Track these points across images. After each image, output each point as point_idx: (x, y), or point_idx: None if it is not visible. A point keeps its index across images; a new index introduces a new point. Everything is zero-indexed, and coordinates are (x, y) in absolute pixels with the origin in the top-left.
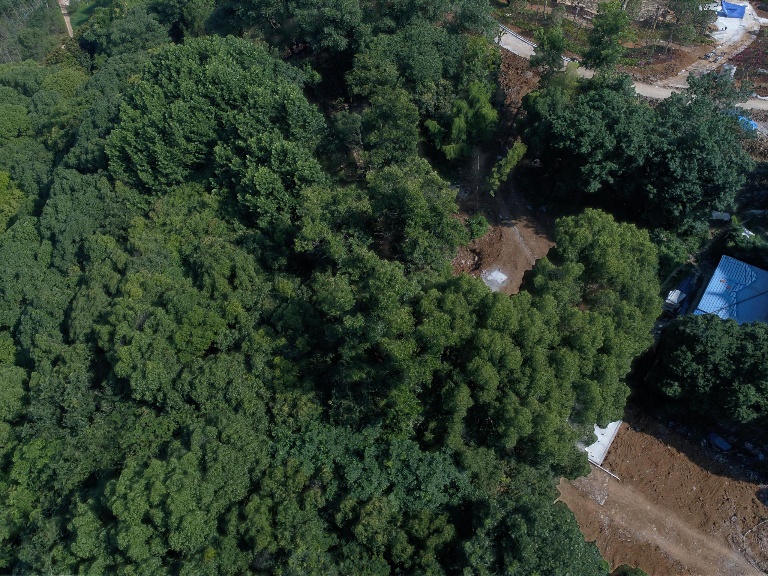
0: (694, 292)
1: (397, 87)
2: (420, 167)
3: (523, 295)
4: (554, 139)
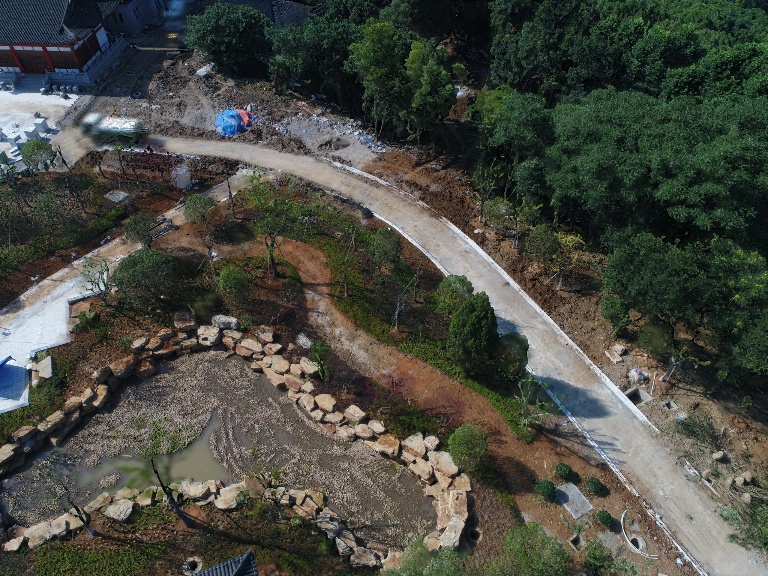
0: None
1: None
2: None
3: None
4: None
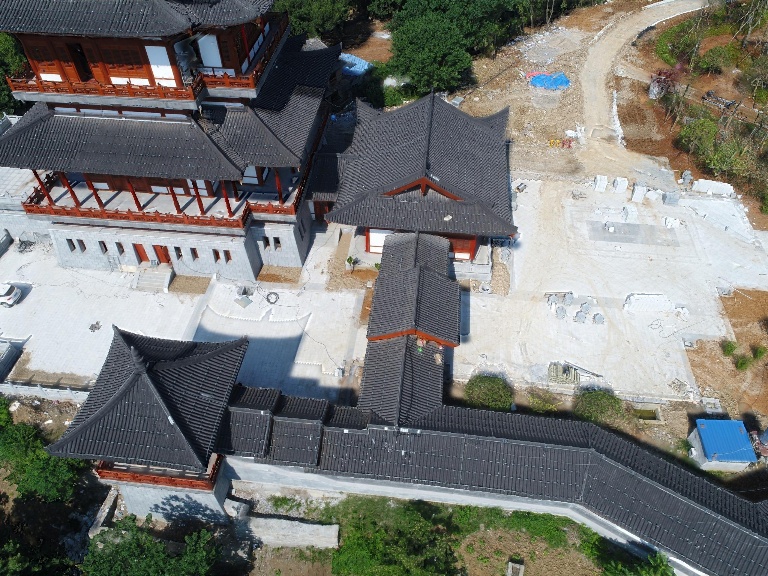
0: None
1: None
2: None
3: None
4: None
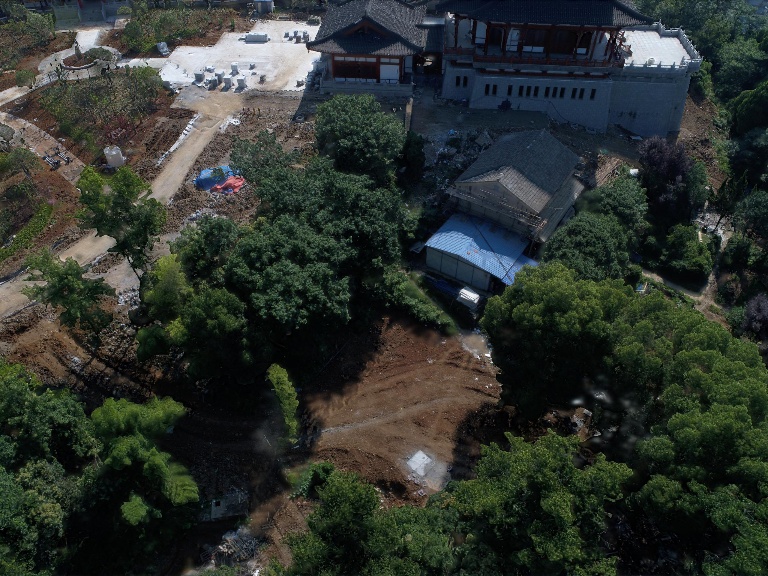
0: (451, 282)
1: (15, 569)
2: (547, 462)
3: (703, 374)
4: (283, 327)
